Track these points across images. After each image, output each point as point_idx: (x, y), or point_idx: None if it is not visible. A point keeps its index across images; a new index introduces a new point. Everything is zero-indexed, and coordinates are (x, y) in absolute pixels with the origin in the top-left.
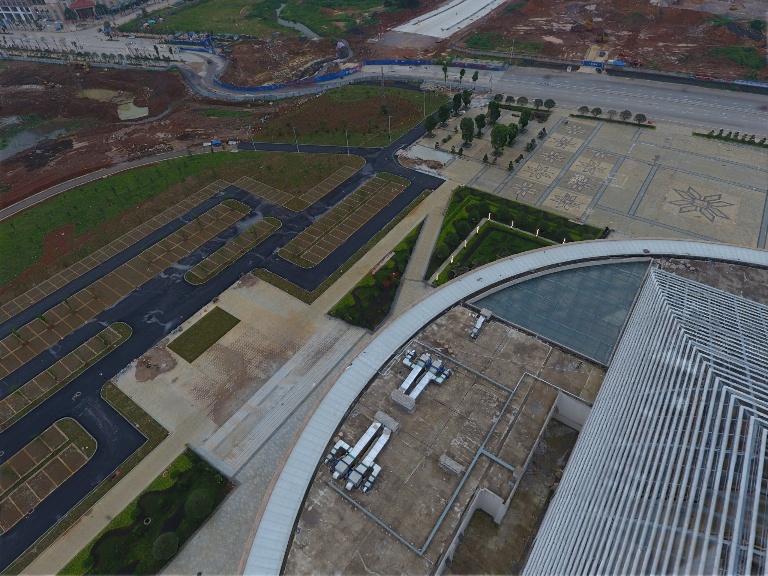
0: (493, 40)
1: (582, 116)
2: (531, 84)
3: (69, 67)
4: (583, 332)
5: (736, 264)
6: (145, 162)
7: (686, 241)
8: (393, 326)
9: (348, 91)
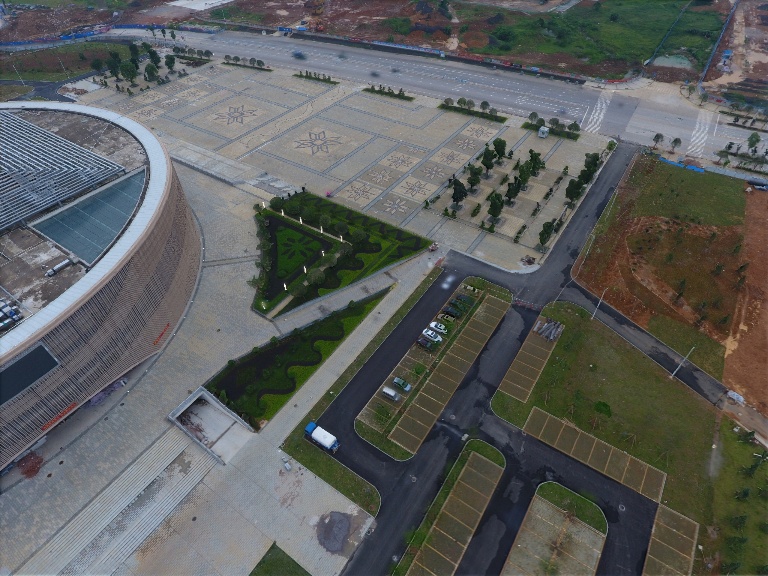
0: (232, 12)
1: (228, 63)
2: (223, 43)
3: None
4: None
5: (68, 113)
6: None
7: (54, 102)
8: None
9: None
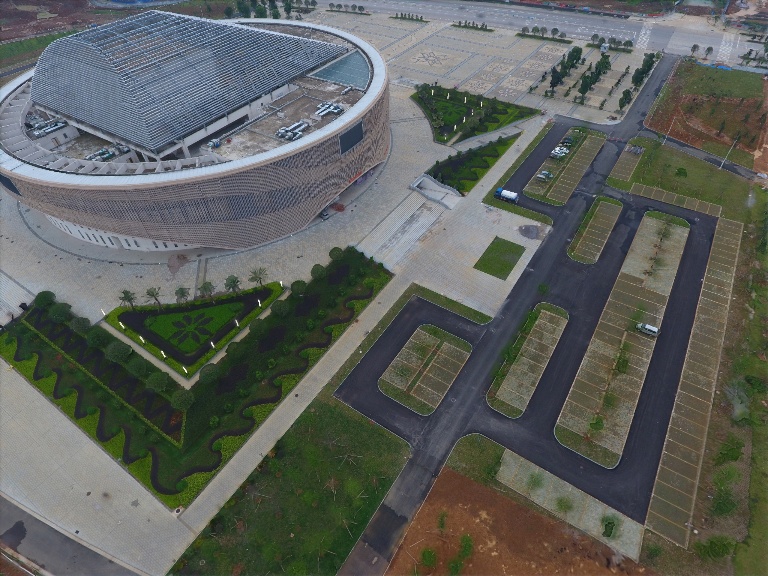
0: None
1: (332, 10)
2: None
3: None
4: None
5: None
6: (46, 34)
7: (260, 19)
8: None
9: None
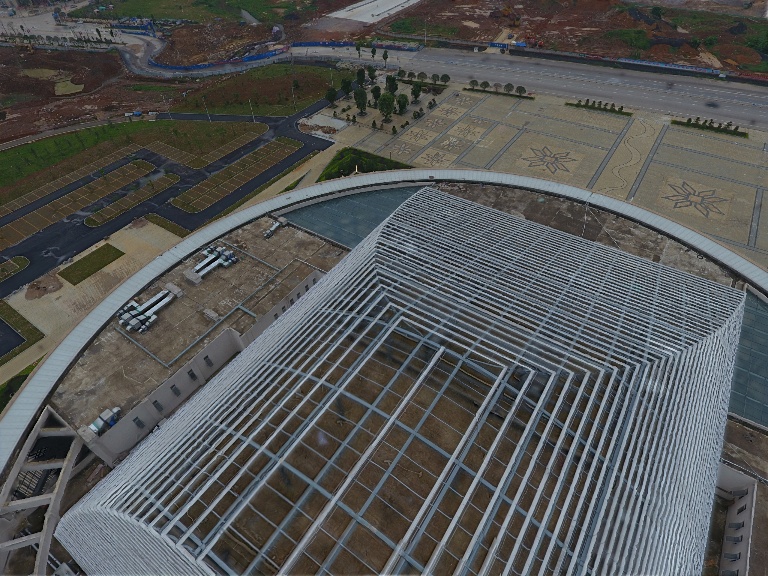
0: (415, 24)
1: (473, 89)
2: (438, 63)
3: (15, 49)
4: (357, 233)
5: (499, 186)
6: (69, 130)
7: (467, 170)
8: (205, 230)
9: (270, 69)
